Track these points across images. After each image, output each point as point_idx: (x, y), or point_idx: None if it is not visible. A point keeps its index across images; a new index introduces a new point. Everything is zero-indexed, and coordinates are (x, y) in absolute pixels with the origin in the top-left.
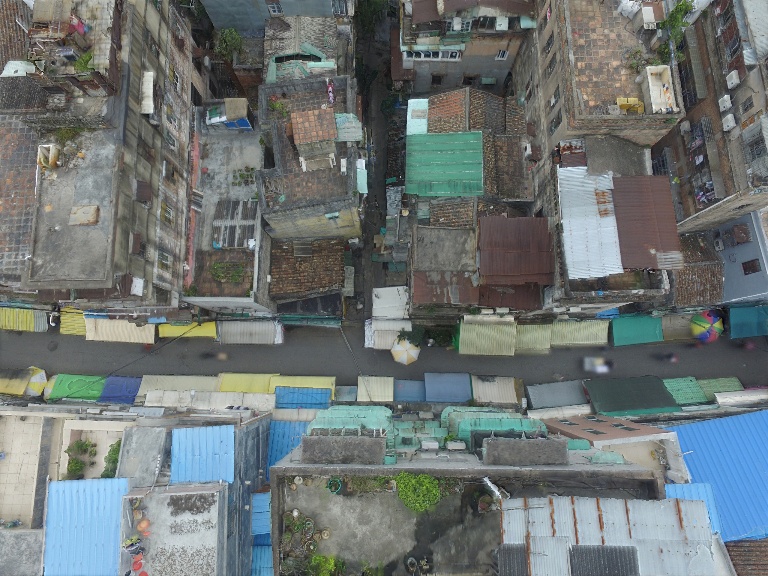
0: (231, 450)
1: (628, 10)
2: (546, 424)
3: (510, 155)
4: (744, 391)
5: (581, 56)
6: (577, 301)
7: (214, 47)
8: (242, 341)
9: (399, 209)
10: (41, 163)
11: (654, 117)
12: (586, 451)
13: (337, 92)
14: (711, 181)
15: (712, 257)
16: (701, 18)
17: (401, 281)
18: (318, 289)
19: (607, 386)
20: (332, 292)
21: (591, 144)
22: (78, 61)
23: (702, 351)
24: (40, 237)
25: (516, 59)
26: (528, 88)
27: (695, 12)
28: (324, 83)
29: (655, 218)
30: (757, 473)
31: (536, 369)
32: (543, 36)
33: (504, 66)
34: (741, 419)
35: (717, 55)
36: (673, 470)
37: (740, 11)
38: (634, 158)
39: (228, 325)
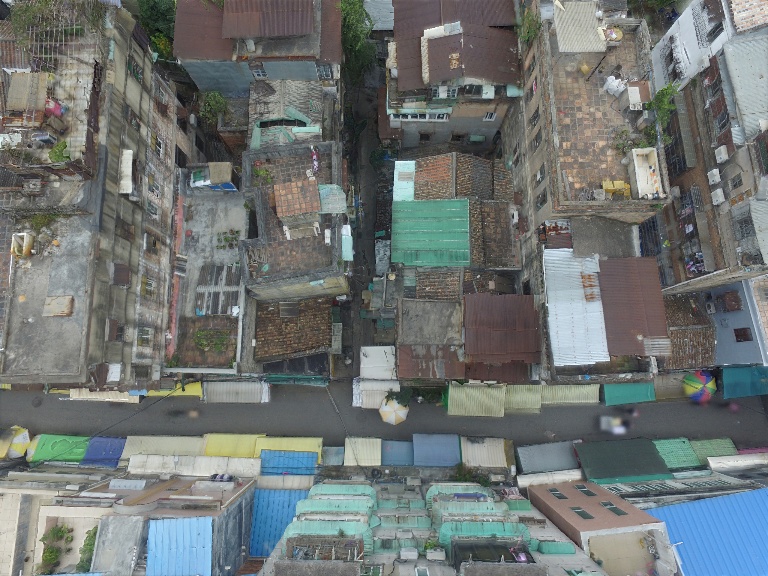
0: (209, 543)
1: (614, 89)
2: (535, 494)
3: (497, 221)
4: (737, 456)
5: (566, 136)
6: (564, 382)
7: (199, 108)
8: (228, 400)
9: (386, 273)
10: (15, 252)
11: (640, 203)
12: (570, 559)
13: (322, 157)
14: (701, 252)
15: (704, 320)
16: (690, 86)
17: (389, 338)
18: (304, 351)
19: (598, 450)
20: (319, 352)
21: (577, 225)
22: (52, 150)
23: (695, 407)
24: (13, 329)
25: (504, 120)
26: (515, 153)
27: (684, 79)
28: (309, 149)
29: (642, 302)
30: (749, 558)
31: (527, 426)
32: (529, 107)
33: (492, 126)
34: (733, 499)
35: (706, 126)
36: (662, 560)
37: (728, 87)
38: (621, 237)
39: (214, 384)
